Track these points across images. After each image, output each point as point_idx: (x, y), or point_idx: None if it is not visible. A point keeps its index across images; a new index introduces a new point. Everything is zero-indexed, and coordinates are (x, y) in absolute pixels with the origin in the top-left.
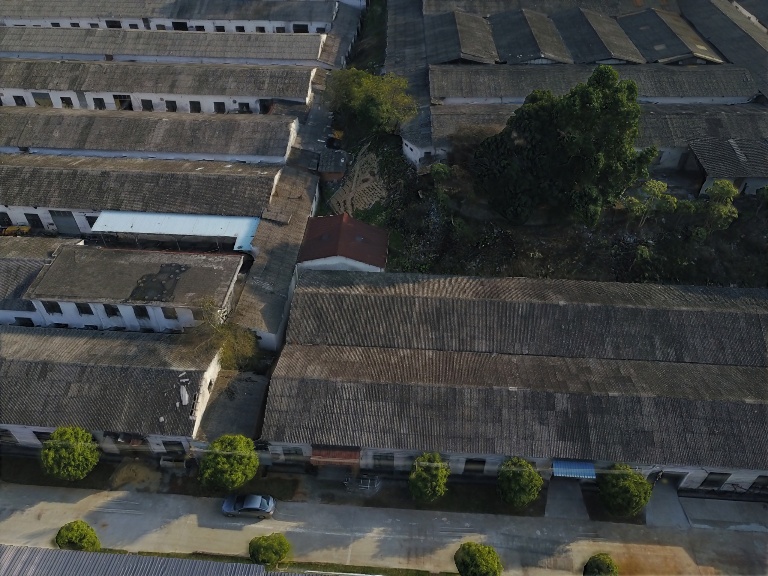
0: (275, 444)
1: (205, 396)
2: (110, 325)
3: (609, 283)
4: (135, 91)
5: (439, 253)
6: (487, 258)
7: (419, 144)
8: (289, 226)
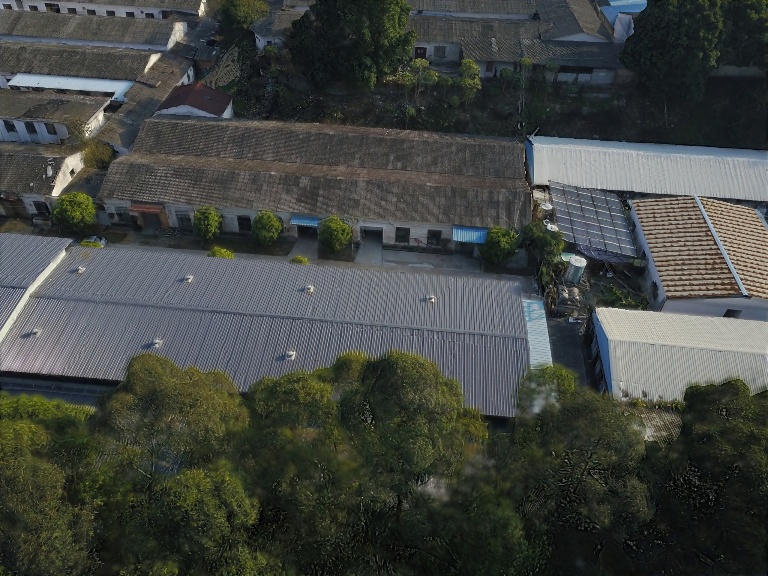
0: (108, 203)
1: (67, 177)
2: (10, 140)
3: (378, 128)
4: (62, 0)
5: (269, 113)
6: (303, 117)
7: (262, 34)
8: (157, 89)
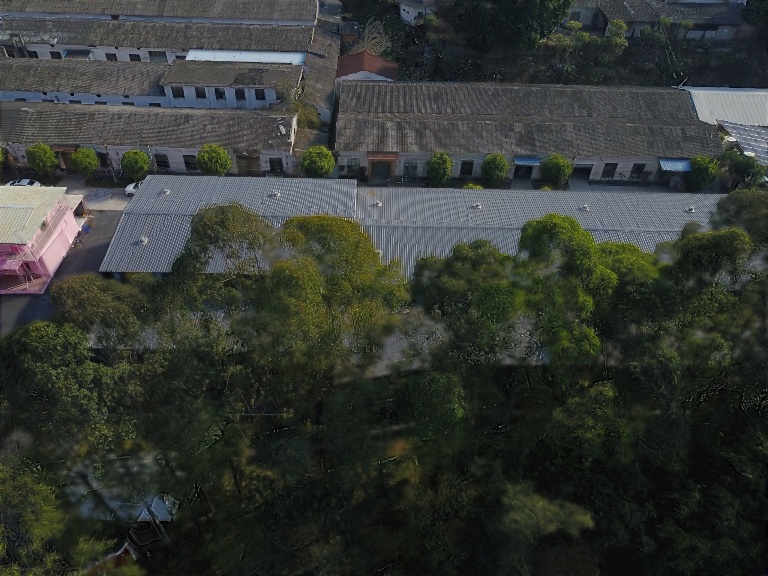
0: (343, 155)
1: (293, 135)
2: None
3: None
4: None
5: (432, 77)
6: (465, 79)
7: (414, 6)
8: (327, 59)
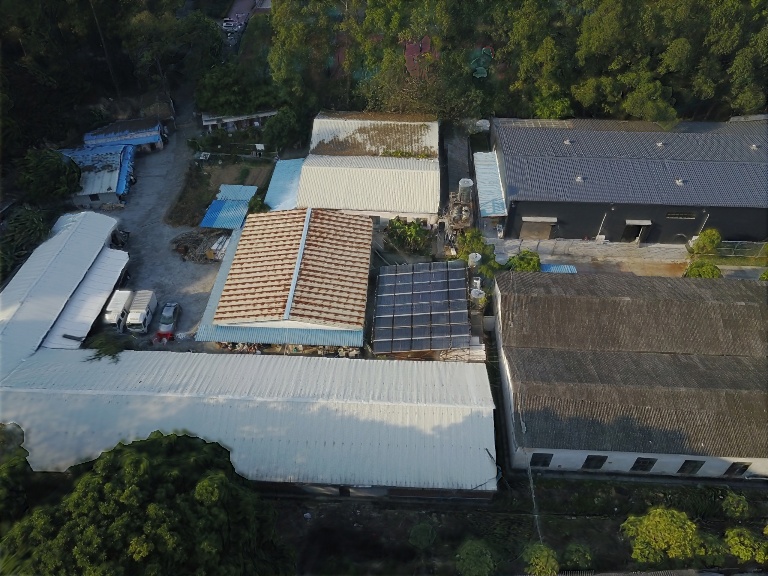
0: None
1: None
2: None
3: (767, 453)
4: None
5: None
6: None
7: None
8: None
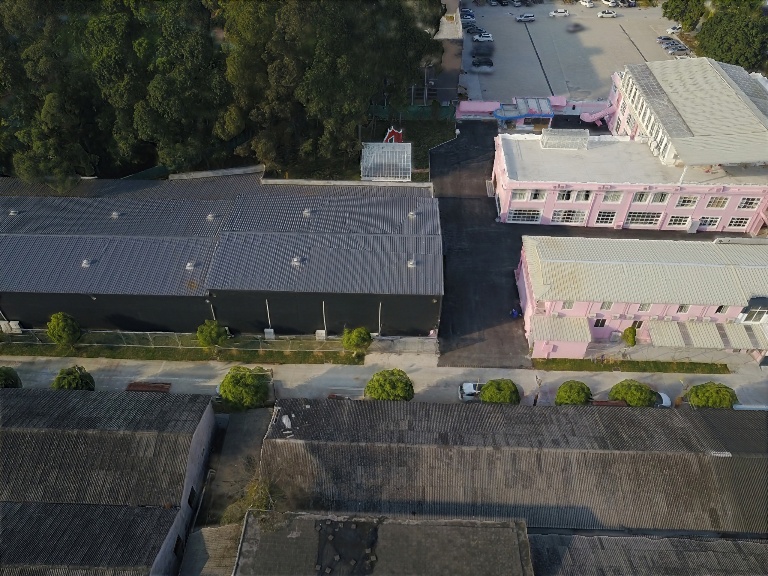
0: None
1: None
2: None
3: None
4: None
5: None
6: None
7: None
8: None
